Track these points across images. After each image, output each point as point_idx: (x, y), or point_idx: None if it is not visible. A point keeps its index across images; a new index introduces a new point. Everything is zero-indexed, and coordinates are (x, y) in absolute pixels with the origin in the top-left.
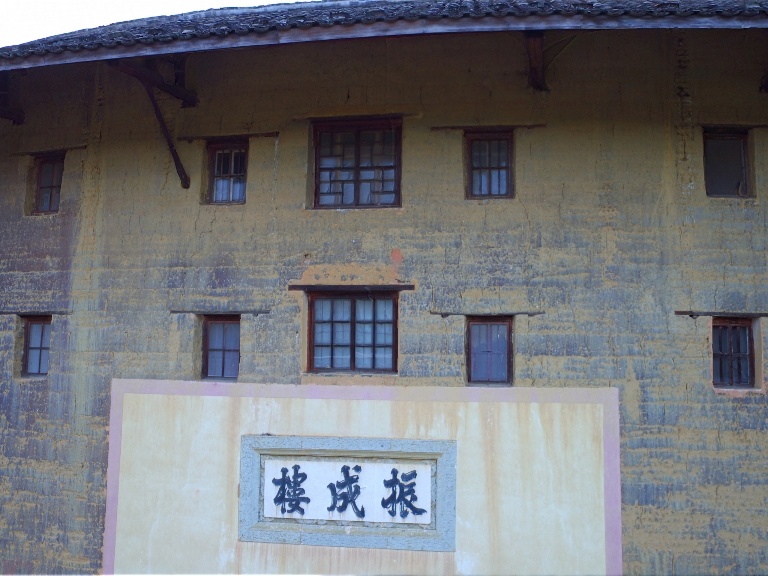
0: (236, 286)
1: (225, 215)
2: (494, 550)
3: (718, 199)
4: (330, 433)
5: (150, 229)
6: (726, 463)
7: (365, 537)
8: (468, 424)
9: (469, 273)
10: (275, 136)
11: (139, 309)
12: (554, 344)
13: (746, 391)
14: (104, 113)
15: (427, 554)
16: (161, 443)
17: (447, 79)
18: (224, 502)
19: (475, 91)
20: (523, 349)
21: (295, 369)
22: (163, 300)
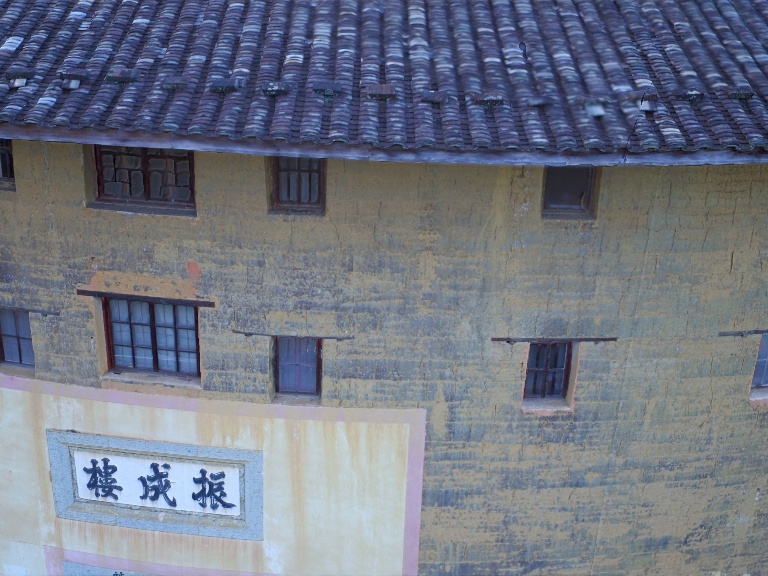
0: (19, 283)
1: None
2: (300, 541)
3: (553, 221)
4: (136, 435)
5: None
6: (526, 472)
7: (177, 525)
8: (274, 437)
9: (273, 295)
10: None
11: None
12: (363, 368)
13: (554, 410)
14: None
15: (237, 541)
16: None
17: None
18: (38, 484)
19: None
20: (330, 372)
21: (94, 373)
22: None
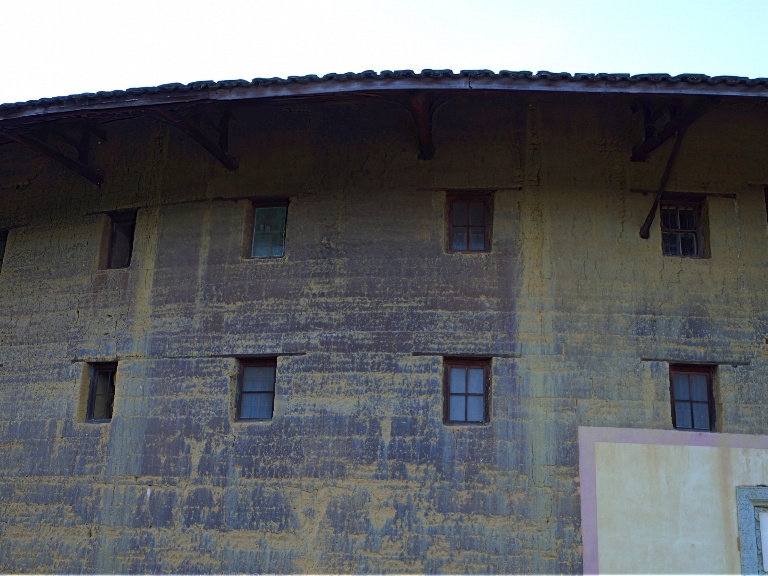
0: (712, 337)
1: (692, 267)
2: None
3: None
4: None
5: (610, 275)
6: None
7: None
8: None
9: None
10: (733, 197)
11: (604, 355)
12: None
13: None
14: (541, 157)
15: None
16: (645, 495)
17: None
18: (724, 556)
19: None
20: None
21: None
22: (632, 347)
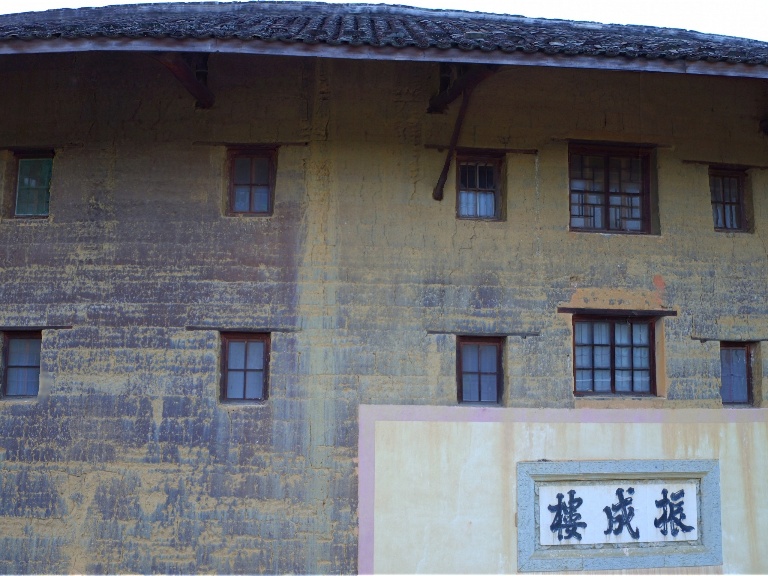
0: (502, 307)
1: (486, 232)
2: (754, 560)
3: None
4: (606, 457)
5: (399, 241)
6: None
7: (644, 558)
8: (728, 443)
9: (723, 301)
10: (534, 154)
11: (389, 328)
12: None
13: None
14: (330, 108)
15: (700, 569)
16: (424, 474)
17: (694, 115)
18: (501, 533)
19: (718, 130)
20: None
21: (568, 393)
22: (419, 319)
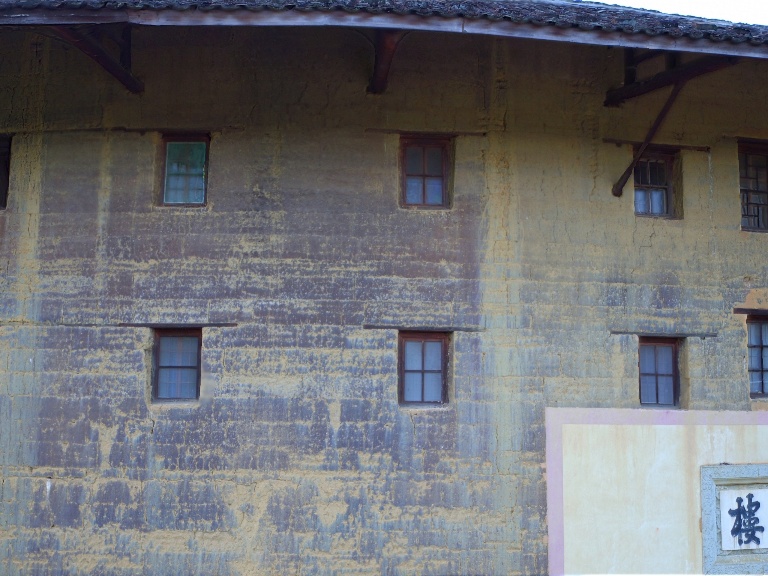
0: (682, 307)
1: (665, 230)
2: None
3: None
4: None
5: (581, 238)
6: None
7: None
8: None
9: None
10: (707, 151)
11: (574, 328)
12: None
13: None
14: (507, 98)
15: None
16: (612, 479)
17: None
18: (686, 539)
19: None
20: None
21: (745, 395)
22: (602, 319)
